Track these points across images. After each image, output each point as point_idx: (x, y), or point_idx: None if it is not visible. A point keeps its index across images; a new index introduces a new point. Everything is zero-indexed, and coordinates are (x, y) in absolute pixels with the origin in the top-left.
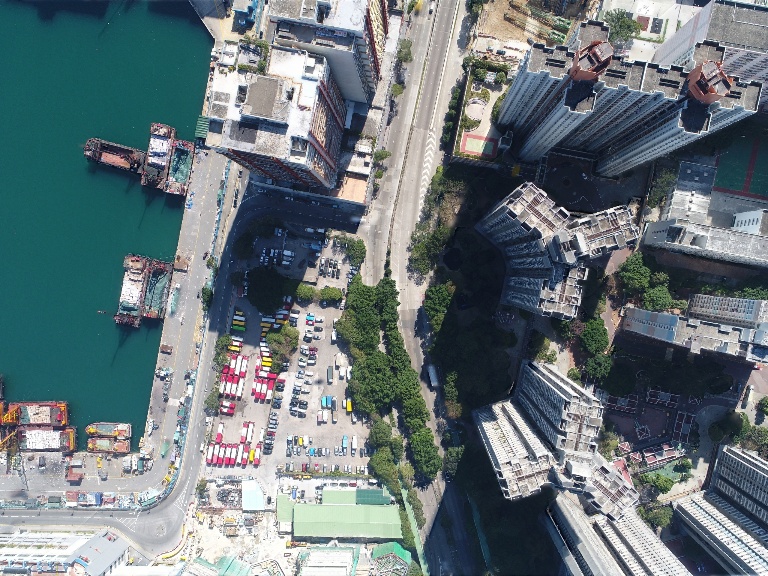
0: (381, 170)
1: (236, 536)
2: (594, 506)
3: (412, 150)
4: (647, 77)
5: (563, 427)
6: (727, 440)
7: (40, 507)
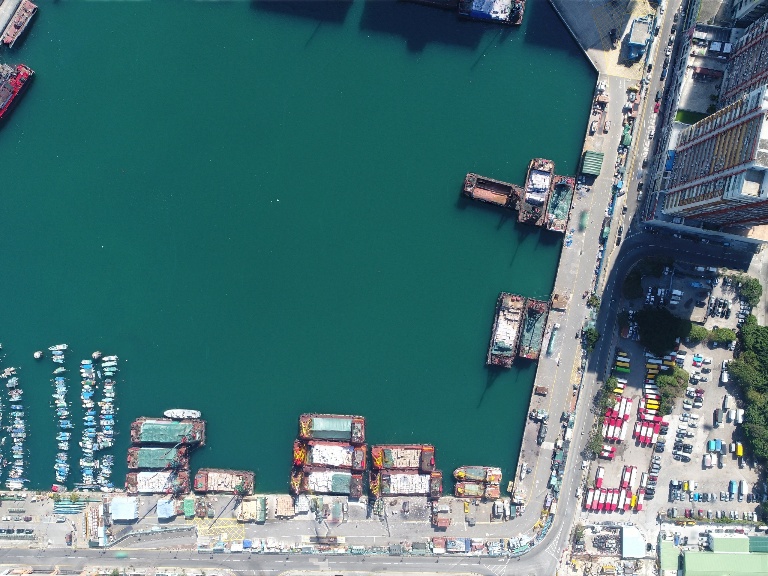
0: None
1: None
2: None
3: None
4: None
5: None
6: None
7: (403, 553)
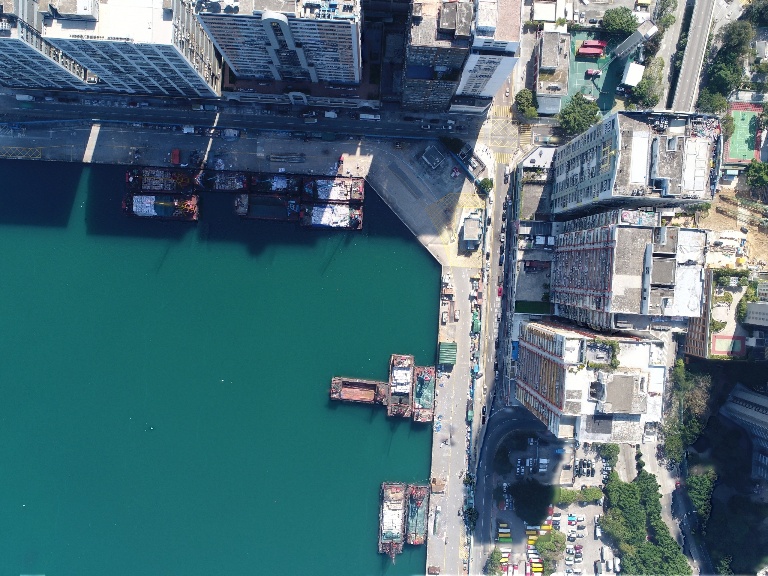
0: None
1: None
2: None
3: None
4: None
5: None
6: None
7: None
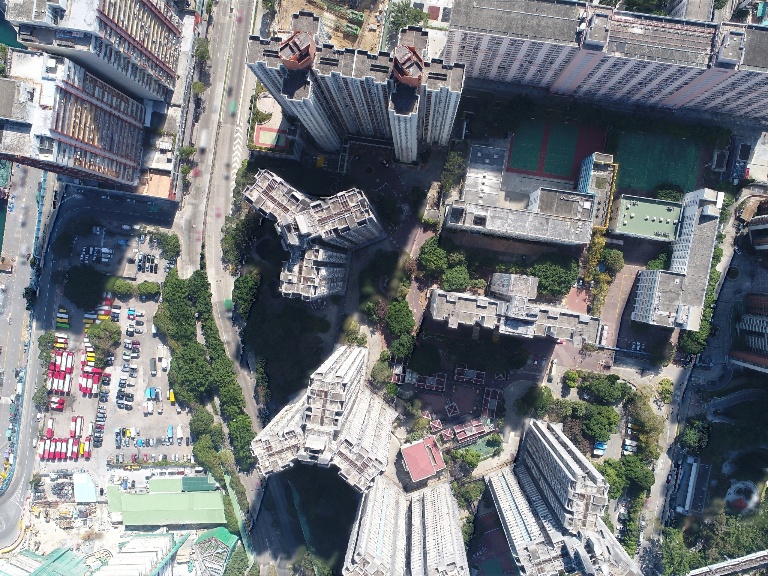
0: (187, 166)
1: (72, 528)
2: None
3: (221, 145)
4: (358, 63)
5: (309, 403)
6: (535, 414)
7: None
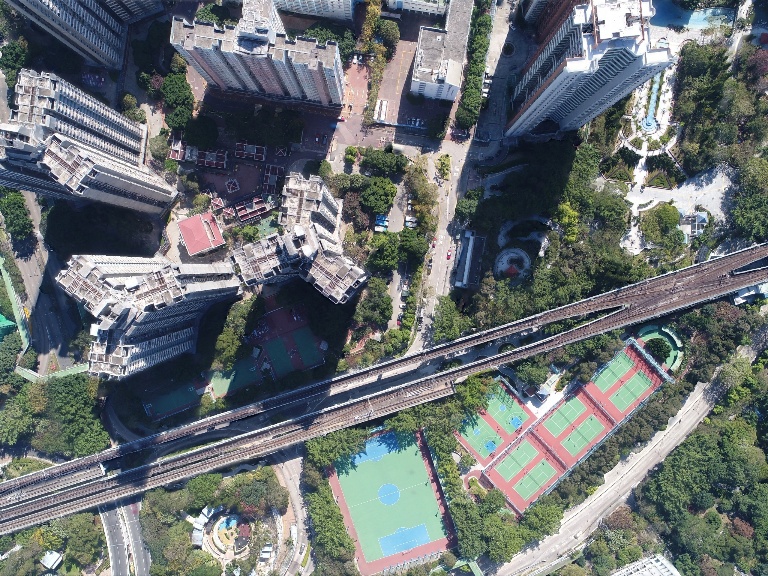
0: None
1: None
2: (56, 180)
3: None
4: None
5: None
6: None
7: None
